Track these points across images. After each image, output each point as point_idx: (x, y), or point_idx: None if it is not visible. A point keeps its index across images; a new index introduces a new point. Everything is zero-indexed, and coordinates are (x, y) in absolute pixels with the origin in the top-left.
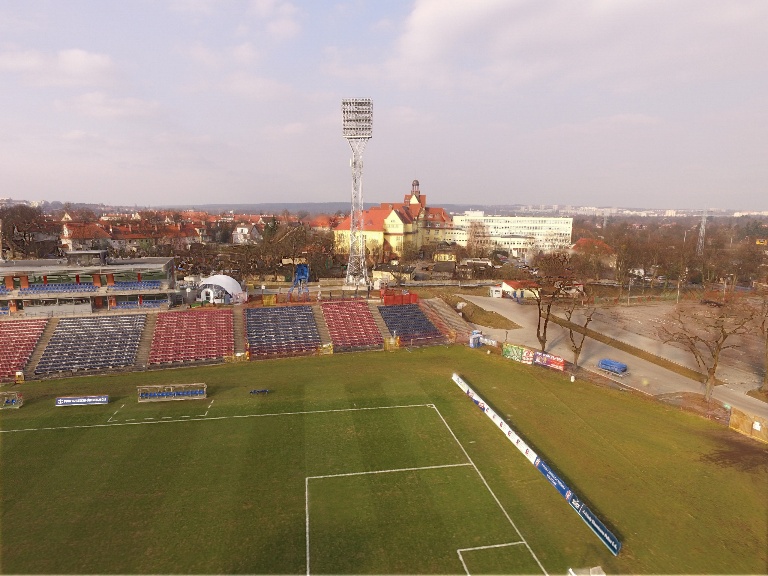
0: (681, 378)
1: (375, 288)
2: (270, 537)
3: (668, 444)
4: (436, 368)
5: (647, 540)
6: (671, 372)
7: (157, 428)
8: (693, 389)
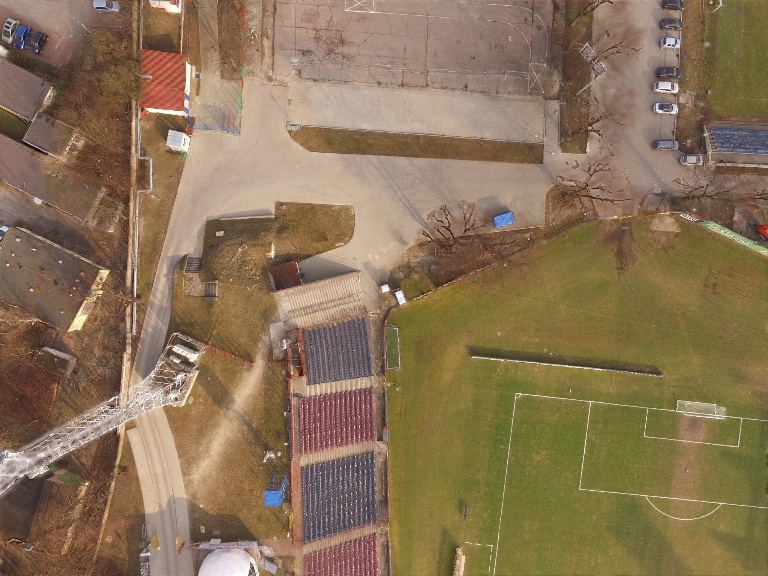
0: (525, 172)
1: (195, 359)
2: (617, 508)
3: (602, 278)
4: (446, 361)
5: (661, 358)
6: (511, 167)
7: (504, 572)
8: (545, 184)
